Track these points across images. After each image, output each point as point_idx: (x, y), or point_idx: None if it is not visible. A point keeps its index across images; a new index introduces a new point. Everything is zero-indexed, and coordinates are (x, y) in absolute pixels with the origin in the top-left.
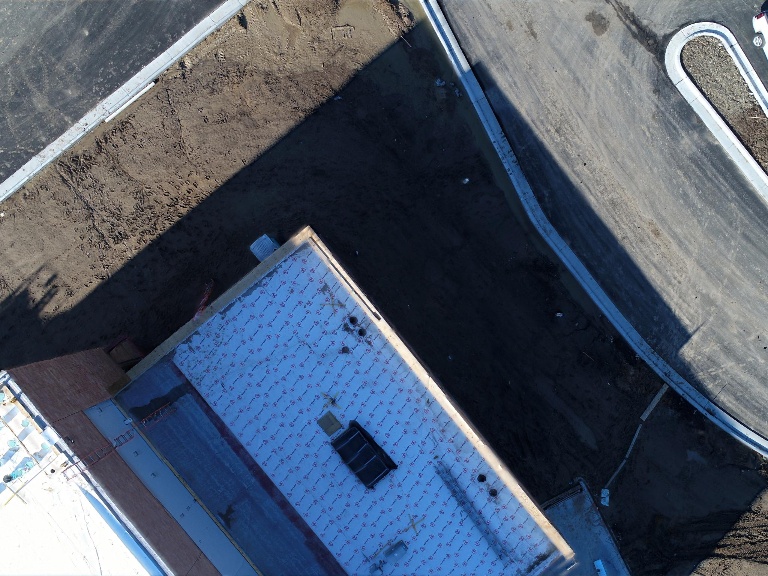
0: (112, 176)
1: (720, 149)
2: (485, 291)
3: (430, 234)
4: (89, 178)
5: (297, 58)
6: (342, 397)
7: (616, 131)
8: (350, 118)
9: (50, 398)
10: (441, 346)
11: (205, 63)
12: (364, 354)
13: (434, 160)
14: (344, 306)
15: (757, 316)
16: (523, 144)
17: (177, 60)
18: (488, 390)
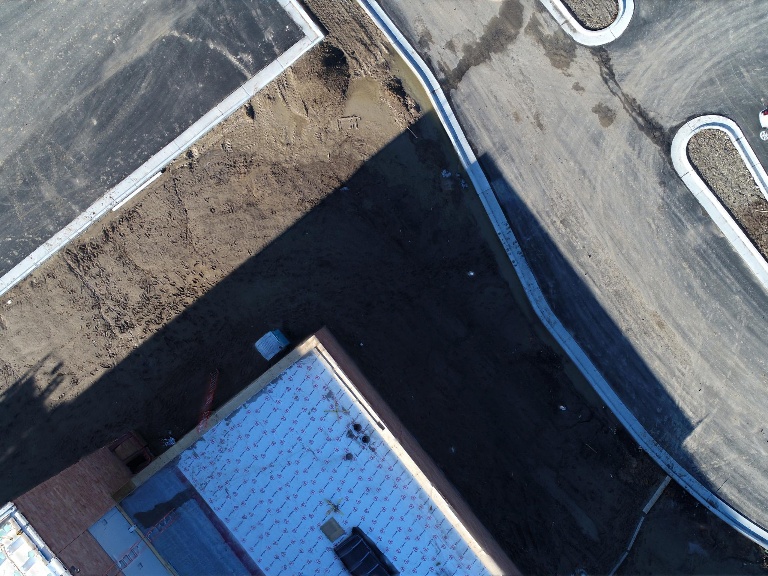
0: (119, 265)
1: (725, 242)
2: (489, 382)
3: (434, 325)
4: (96, 266)
5: (303, 148)
6: (345, 503)
7: (621, 223)
8: (356, 209)
9: (56, 523)
10: (444, 437)
11: (212, 153)
12: (368, 461)
13: (439, 251)
14: (348, 413)
15: (761, 409)
16: (528, 235)
17: (184, 150)
18: (491, 481)
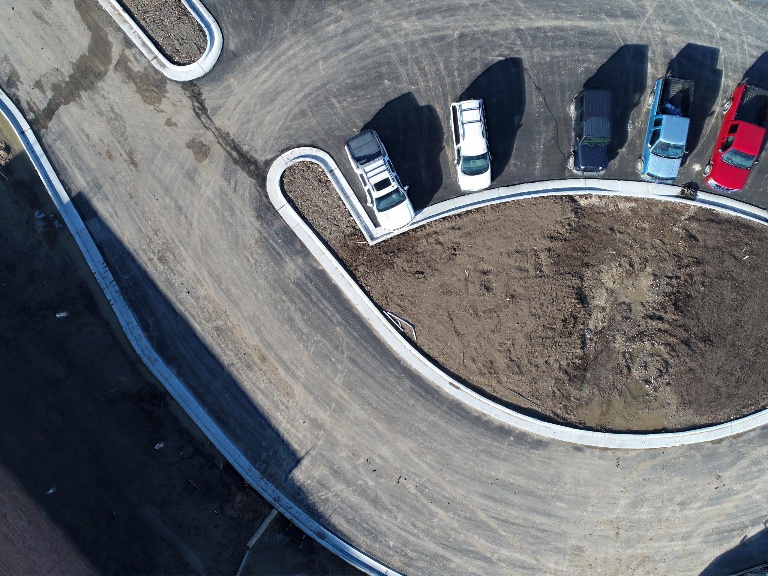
0: None
1: (324, 274)
2: (88, 423)
3: (31, 367)
4: None
5: None
6: None
7: (219, 258)
8: None
9: None
10: (44, 479)
11: None
12: None
13: (35, 293)
14: None
15: (366, 439)
16: (126, 274)
17: None
18: (93, 521)
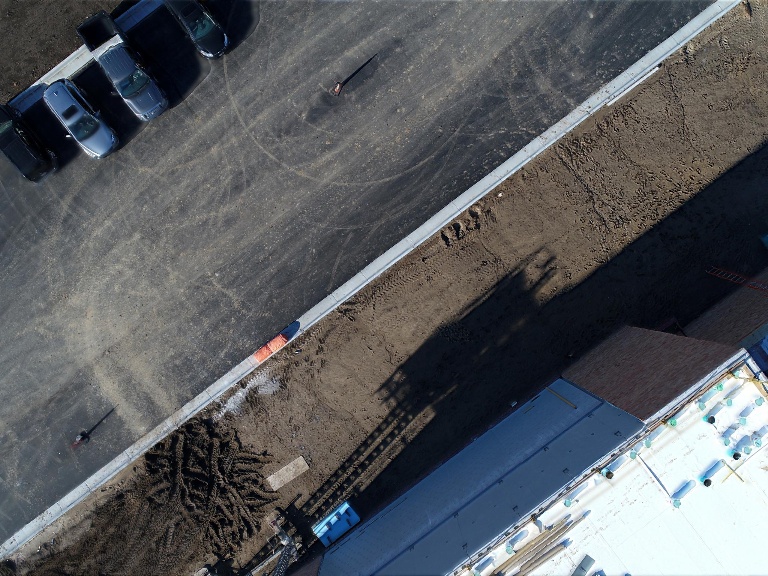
0: (613, 160)
1: None
2: None
3: None
4: (590, 161)
5: None
6: None
7: None
8: None
9: None
10: None
11: (709, 49)
12: None
13: None
14: None
15: None
16: None
17: (682, 45)
18: None
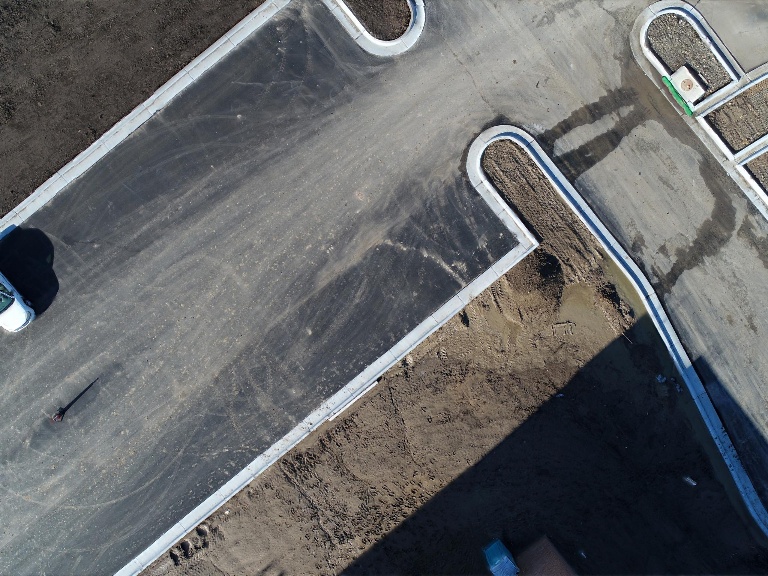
0: (337, 475)
1: None
2: None
3: (652, 531)
4: (313, 477)
5: (518, 355)
6: None
7: None
8: (572, 415)
9: None
10: None
11: (427, 361)
12: None
13: (655, 456)
14: None
15: None
16: (743, 438)
17: (400, 359)
18: None
